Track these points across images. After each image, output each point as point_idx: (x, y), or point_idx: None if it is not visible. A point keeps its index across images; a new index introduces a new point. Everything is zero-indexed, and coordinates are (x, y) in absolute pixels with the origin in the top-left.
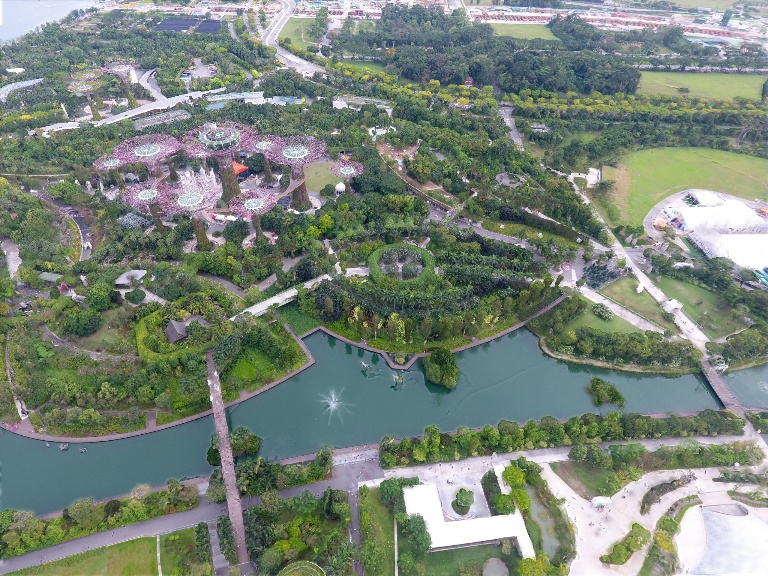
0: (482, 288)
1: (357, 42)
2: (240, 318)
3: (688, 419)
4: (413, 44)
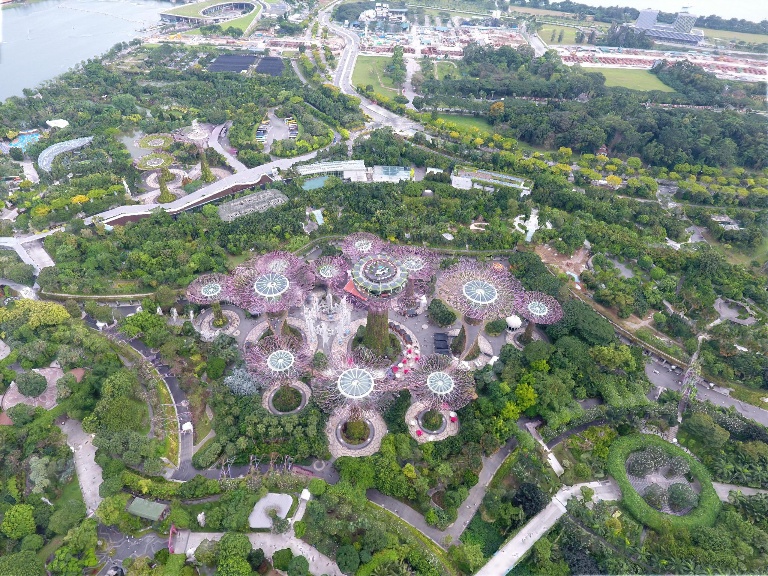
0: None
1: (447, 90)
2: None
3: None
4: (515, 95)
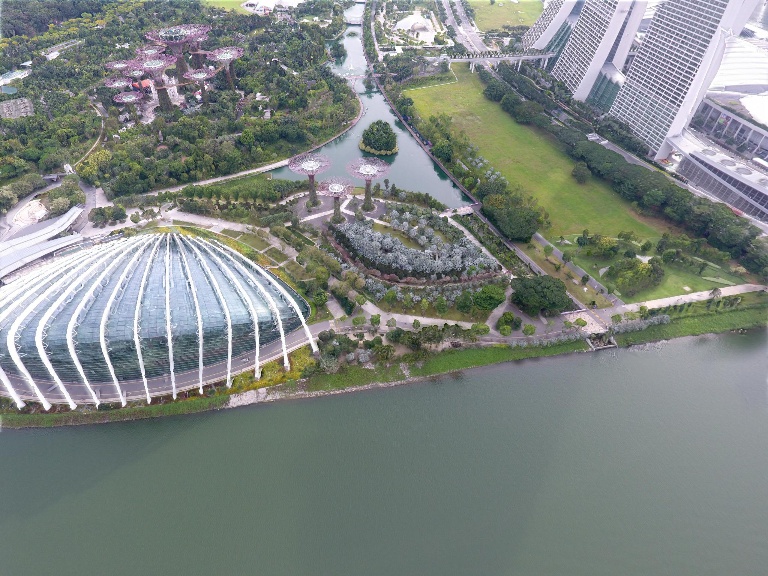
0: None
1: None
2: None
3: None
4: None
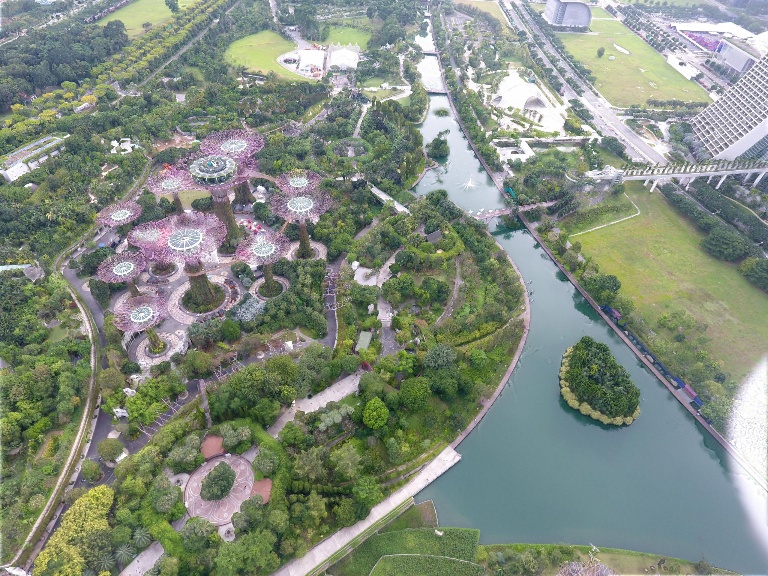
0: (381, 123)
1: None
2: (416, 209)
3: (461, 95)
4: None
